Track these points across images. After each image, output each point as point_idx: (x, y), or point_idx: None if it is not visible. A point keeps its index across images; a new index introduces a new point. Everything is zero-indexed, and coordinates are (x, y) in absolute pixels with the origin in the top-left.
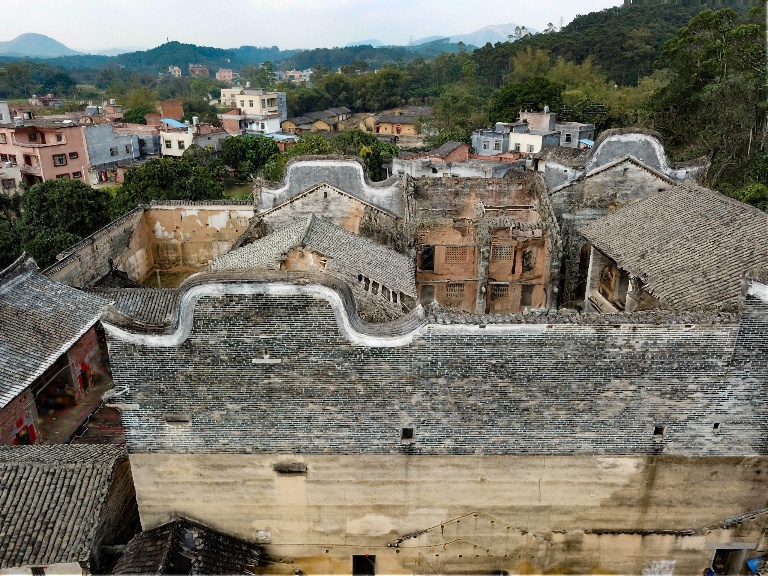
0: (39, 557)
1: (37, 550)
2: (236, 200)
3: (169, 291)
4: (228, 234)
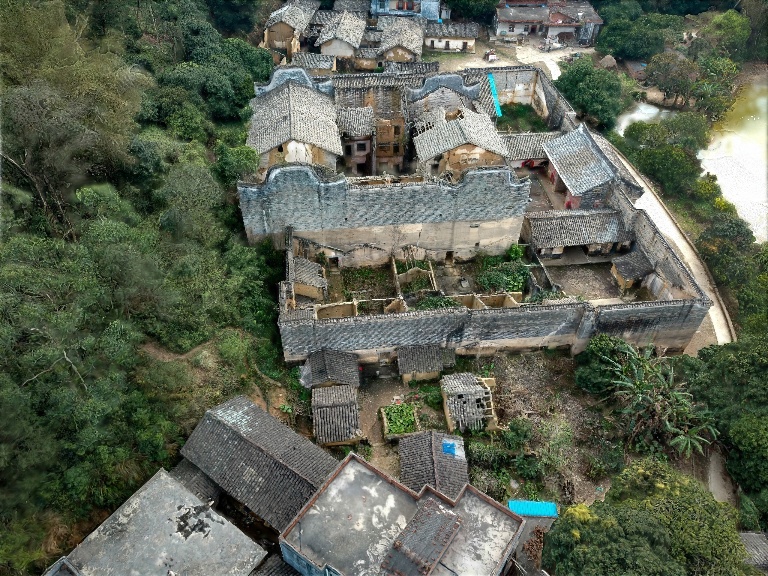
0: None
1: None
2: None
3: None
4: None
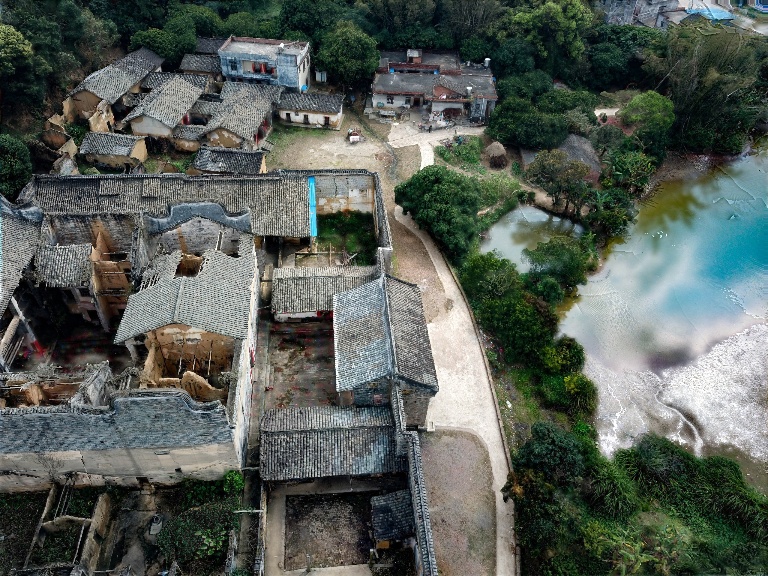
0: None
1: None
2: None
3: None
4: None
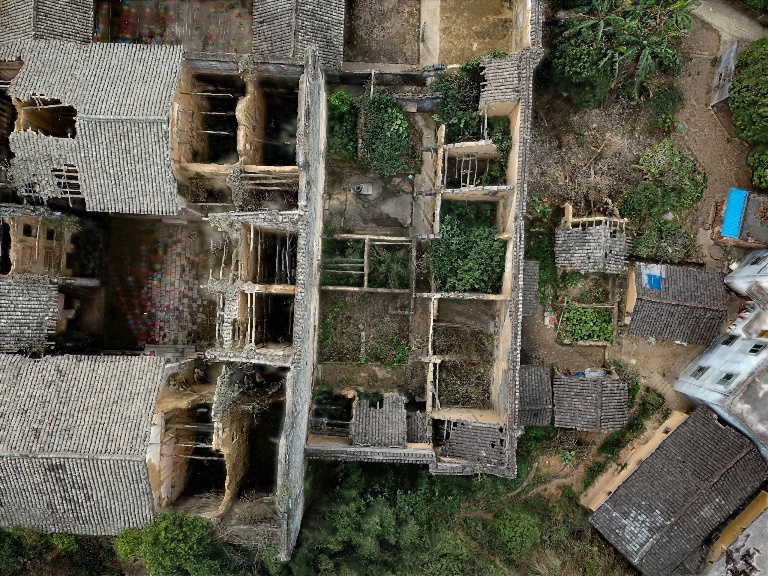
0: (1, 34)
1: (4, 31)
2: (537, 8)
3: (293, 2)
4: (525, 16)
